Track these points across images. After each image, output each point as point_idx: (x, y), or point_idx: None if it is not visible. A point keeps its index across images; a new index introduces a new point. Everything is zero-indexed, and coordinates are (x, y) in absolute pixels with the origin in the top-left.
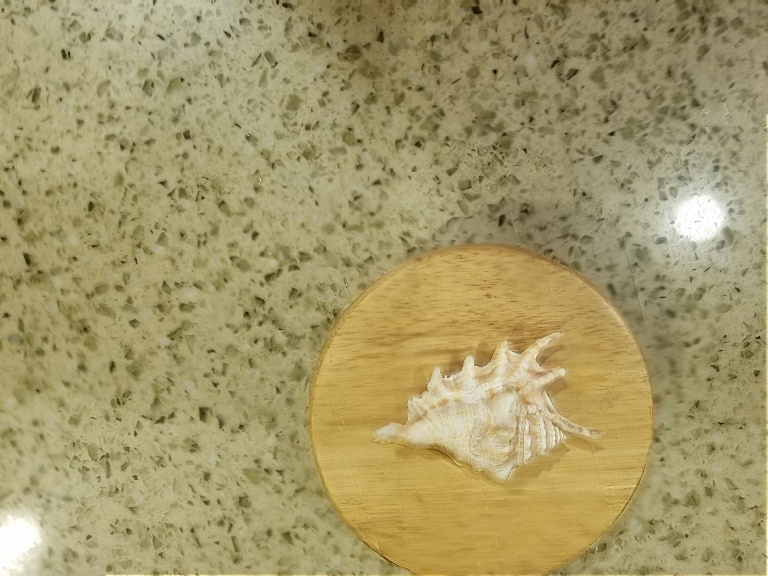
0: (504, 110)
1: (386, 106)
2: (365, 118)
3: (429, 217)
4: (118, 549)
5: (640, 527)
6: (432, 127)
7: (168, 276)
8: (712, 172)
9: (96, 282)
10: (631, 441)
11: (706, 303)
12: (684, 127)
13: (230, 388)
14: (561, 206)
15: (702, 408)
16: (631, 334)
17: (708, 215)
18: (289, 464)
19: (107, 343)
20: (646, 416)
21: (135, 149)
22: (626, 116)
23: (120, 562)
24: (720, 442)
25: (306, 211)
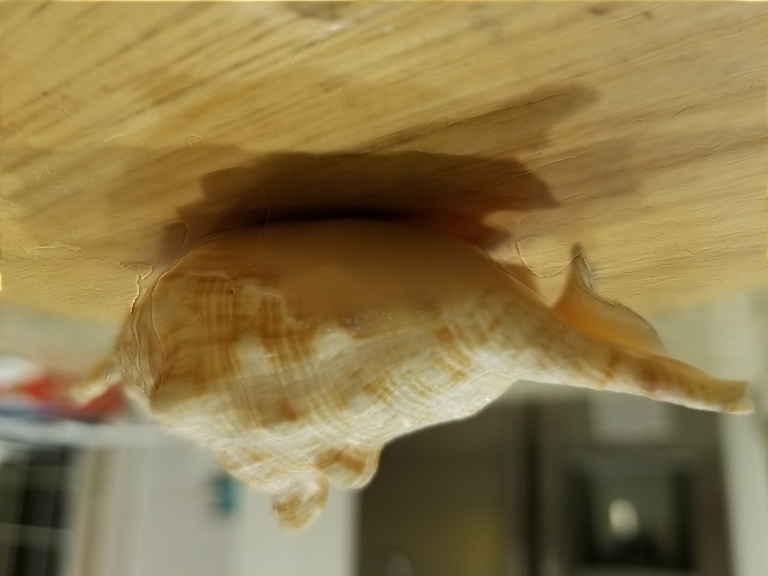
0: None
1: None
2: None
3: None
4: None
5: None
6: None
7: None
8: None
9: None
10: None
11: None
12: None
13: None
14: None
15: None
16: None
17: None
18: None
19: None
20: None
21: None
22: None
23: None
24: None
25: None
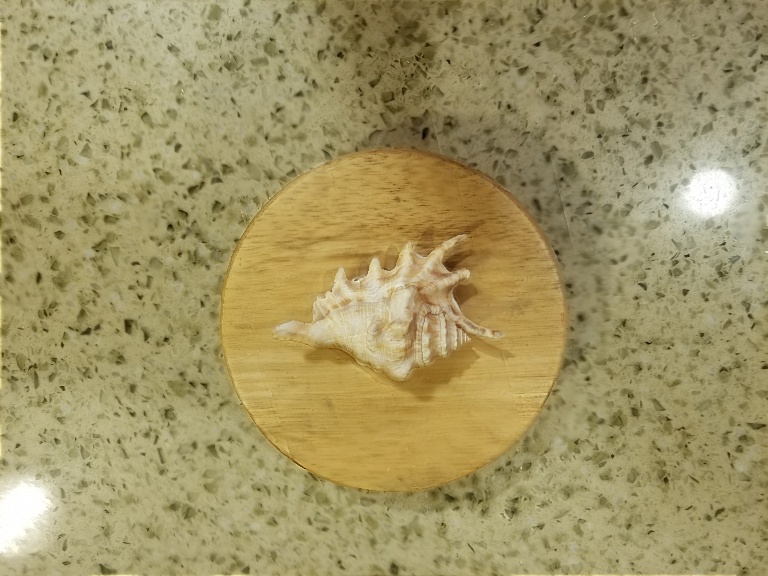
0: (427, 20)
1: (307, 15)
2: (287, 28)
3: (352, 130)
4: (47, 458)
5: (565, 447)
6: (354, 37)
7: (92, 187)
8: (640, 84)
9: (21, 193)
10: (542, 349)
11: (634, 220)
12: (612, 37)
13: (155, 301)
14: (485, 119)
15: (629, 327)
16: (543, 240)
17: (636, 129)
18: (214, 377)
19: (33, 254)
20: (558, 324)
21: (57, 59)
22: (552, 26)
23: (49, 471)
24: (647, 362)
25: (228, 123)
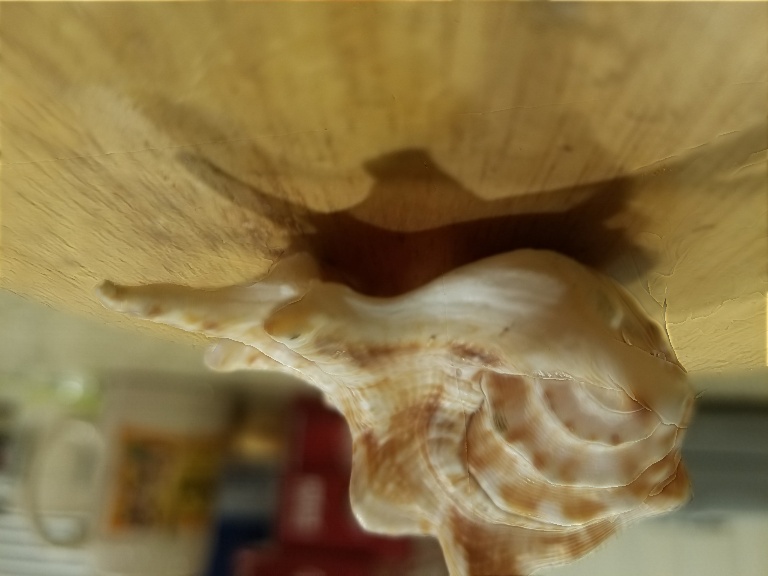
0: None
1: None
2: None
3: None
4: None
5: None
6: None
7: None
8: None
9: None
10: None
11: None
12: None
13: None
14: None
15: None
16: None
17: None
18: None
19: None
20: None
21: None
22: None
23: None
24: None
25: None
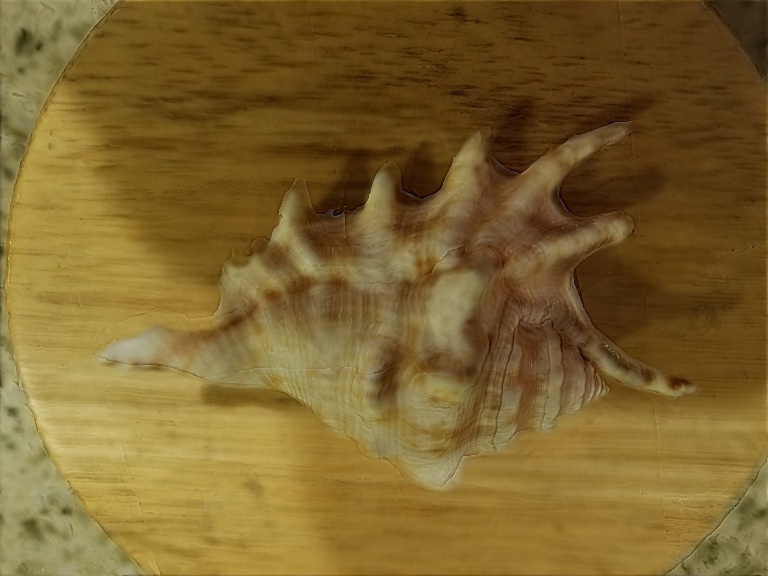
0: None
1: None
2: None
3: None
4: None
5: None
6: None
7: None
8: None
9: None
10: (745, 407)
11: None
12: None
13: None
14: None
15: None
16: None
17: None
18: None
19: None
20: None
21: None
22: None
23: None
24: None
25: None
